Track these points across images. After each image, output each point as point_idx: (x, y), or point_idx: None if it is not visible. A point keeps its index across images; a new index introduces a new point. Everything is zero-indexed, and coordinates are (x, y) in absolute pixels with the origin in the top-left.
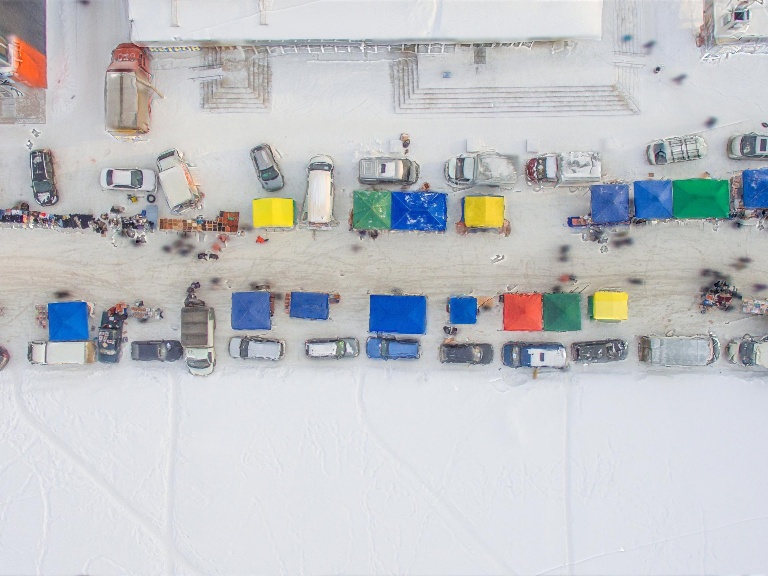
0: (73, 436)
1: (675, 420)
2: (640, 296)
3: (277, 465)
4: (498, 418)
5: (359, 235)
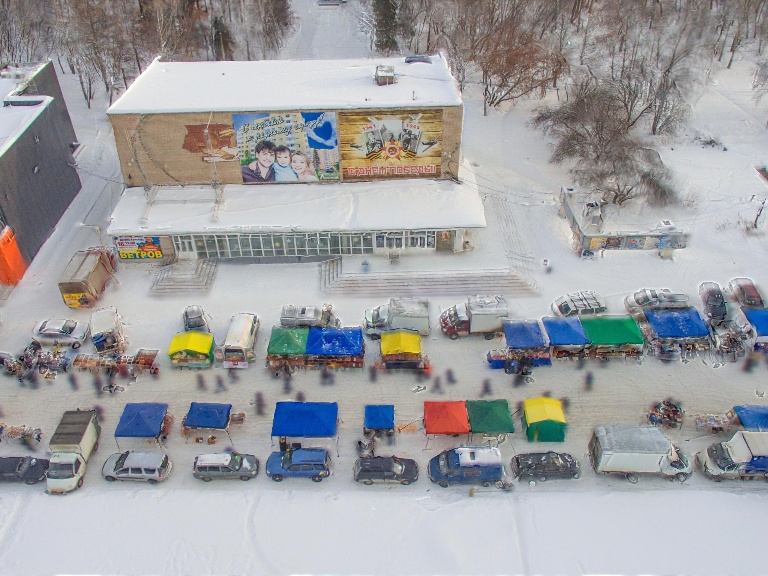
0: None
1: (664, 542)
2: (579, 418)
3: None
4: (428, 540)
5: (275, 372)
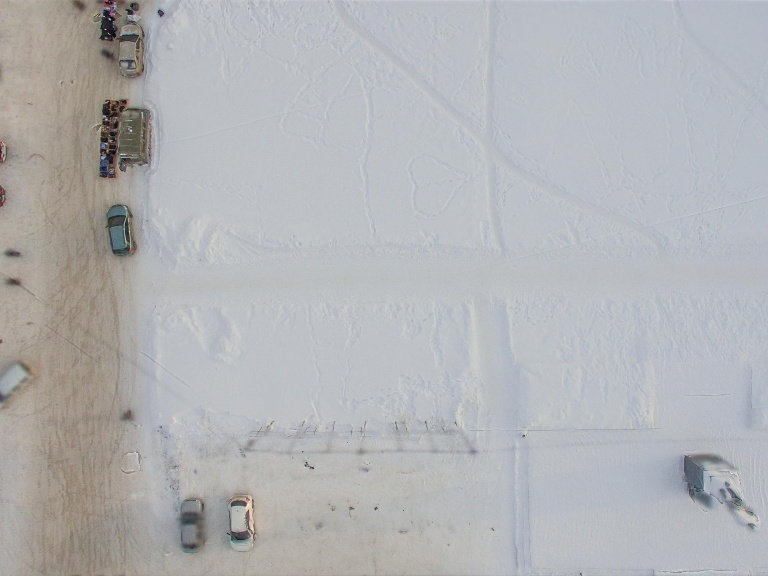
0: (393, 38)
1: None
2: None
3: (594, 69)
4: None
5: None
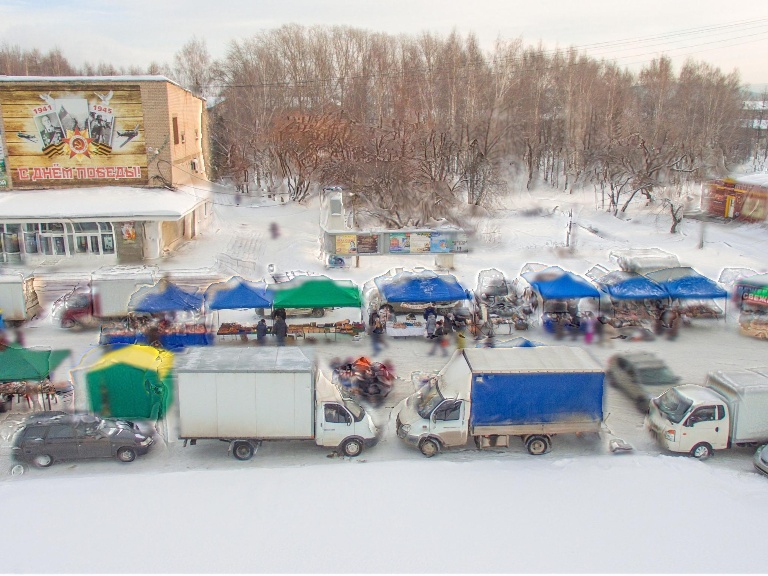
0: None
1: (239, 542)
2: None
3: None
4: None
5: None
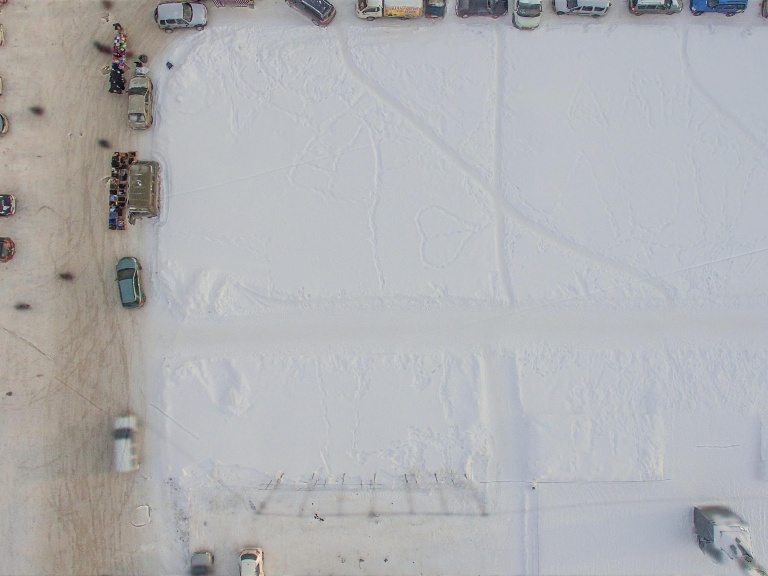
0: (401, 89)
1: None
2: None
3: (602, 119)
4: None
5: None
